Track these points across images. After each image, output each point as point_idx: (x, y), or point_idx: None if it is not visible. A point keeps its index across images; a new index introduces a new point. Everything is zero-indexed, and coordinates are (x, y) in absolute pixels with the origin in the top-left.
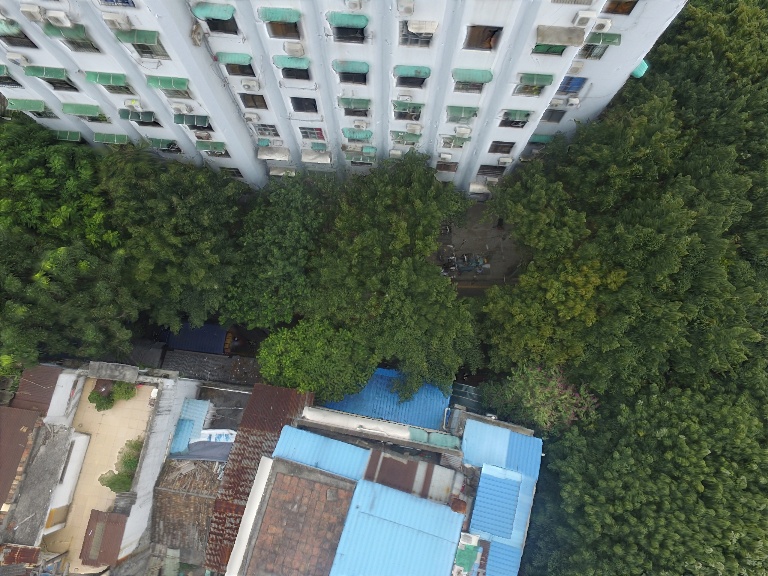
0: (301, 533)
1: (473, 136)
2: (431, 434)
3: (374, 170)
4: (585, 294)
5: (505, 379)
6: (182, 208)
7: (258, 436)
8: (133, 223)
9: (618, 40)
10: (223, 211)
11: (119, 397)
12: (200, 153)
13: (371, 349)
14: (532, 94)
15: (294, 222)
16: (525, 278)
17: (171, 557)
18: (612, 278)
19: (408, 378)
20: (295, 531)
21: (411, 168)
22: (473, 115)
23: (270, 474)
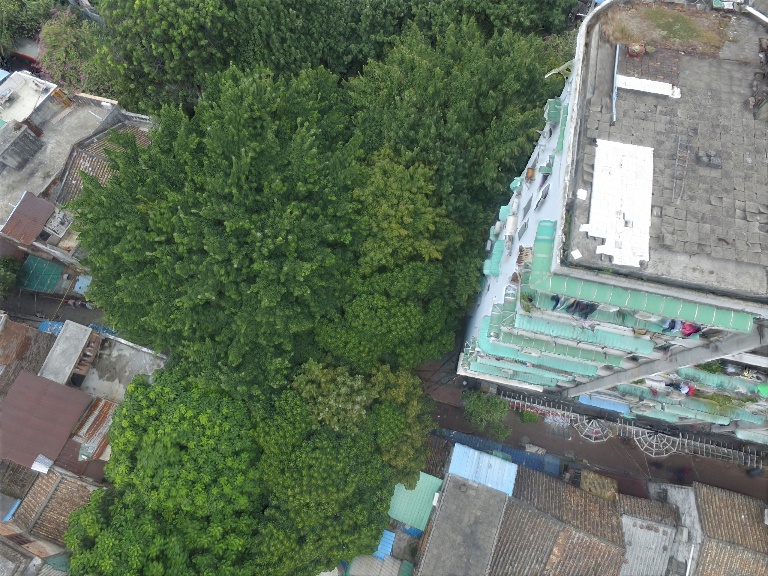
0: None
1: None
2: None
3: None
4: None
5: None
6: None
7: None
8: None
9: None
10: None
11: None
12: None
13: None
14: None
15: None
16: None
17: None
18: None
19: None
20: None
21: None
22: None
23: None
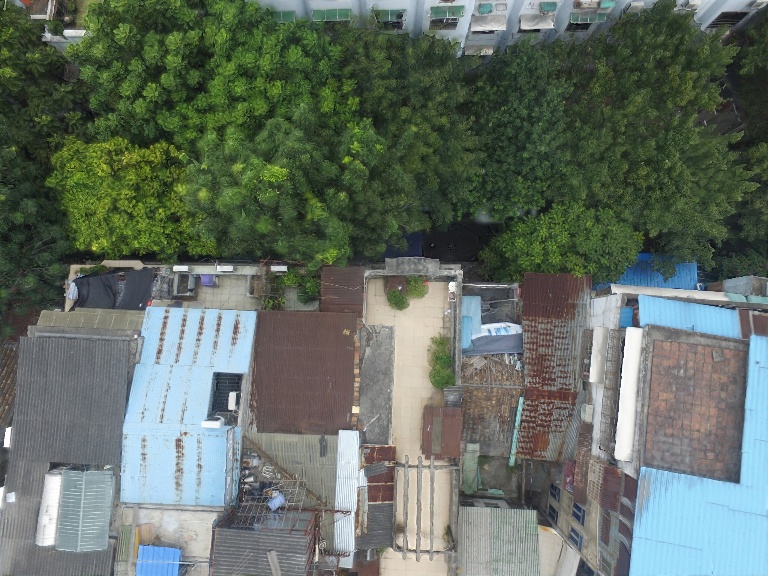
0: (694, 396)
1: None
2: (749, 297)
3: (622, 25)
4: None
5: (750, 249)
6: (441, 83)
7: (546, 324)
8: (390, 106)
9: None
10: (463, 89)
11: (418, 294)
12: (417, 28)
13: (633, 226)
14: None
15: (556, 90)
16: None
17: (471, 451)
18: None
19: (675, 252)
20: (687, 395)
21: (678, 14)
22: None
23: (648, 342)
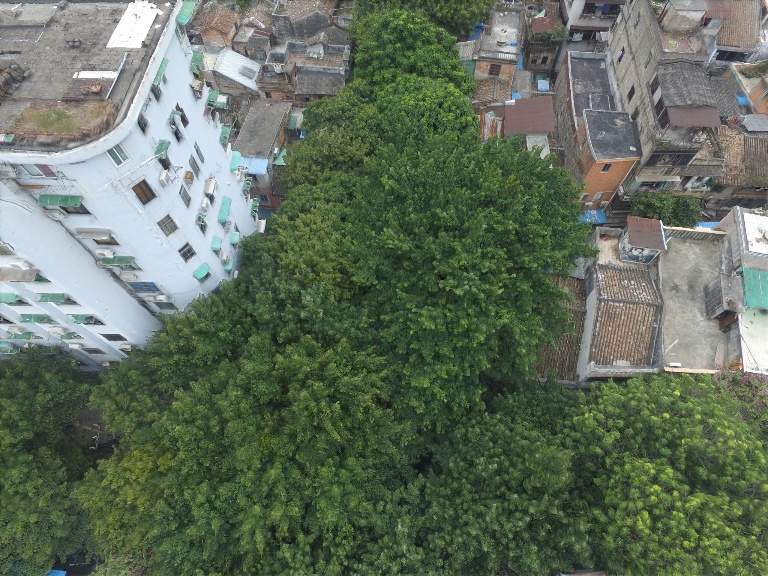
0: None
1: (78, 331)
2: None
3: None
4: (137, 478)
5: None
6: None
7: None
8: None
9: (130, 261)
10: None
11: None
12: None
13: None
14: (75, 304)
15: None
16: (102, 463)
17: None
18: (160, 461)
19: None
20: None
21: (16, 363)
22: (40, 321)
23: None
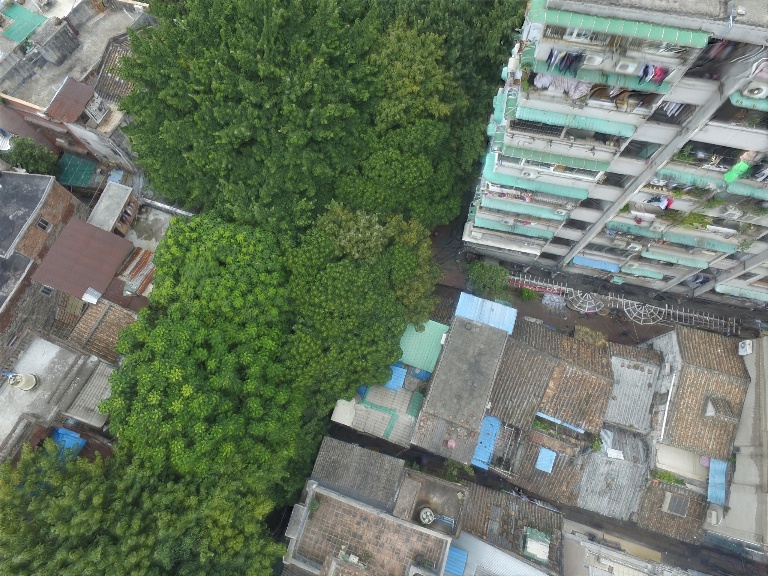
0: None
1: None
2: None
3: None
4: None
5: None
6: None
7: None
8: None
9: None
10: None
11: None
12: None
13: None
14: None
15: None
16: None
17: None
18: None
19: None
20: None
21: None
22: None
23: None
